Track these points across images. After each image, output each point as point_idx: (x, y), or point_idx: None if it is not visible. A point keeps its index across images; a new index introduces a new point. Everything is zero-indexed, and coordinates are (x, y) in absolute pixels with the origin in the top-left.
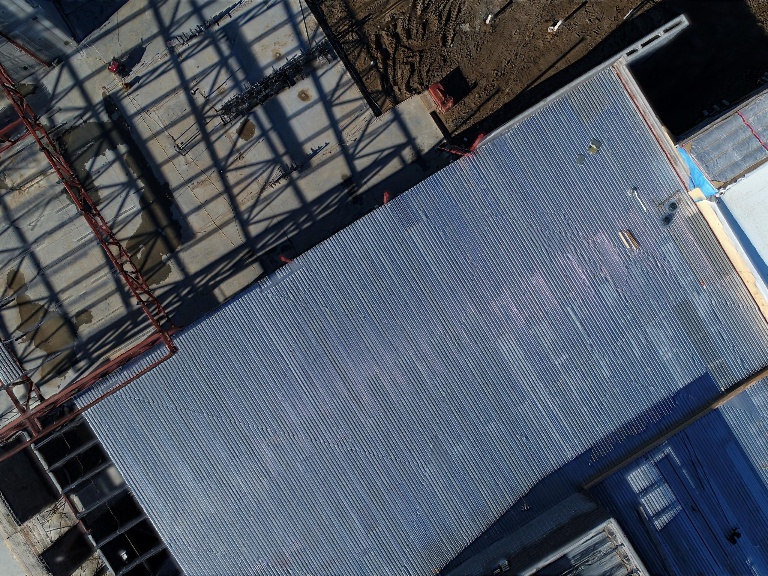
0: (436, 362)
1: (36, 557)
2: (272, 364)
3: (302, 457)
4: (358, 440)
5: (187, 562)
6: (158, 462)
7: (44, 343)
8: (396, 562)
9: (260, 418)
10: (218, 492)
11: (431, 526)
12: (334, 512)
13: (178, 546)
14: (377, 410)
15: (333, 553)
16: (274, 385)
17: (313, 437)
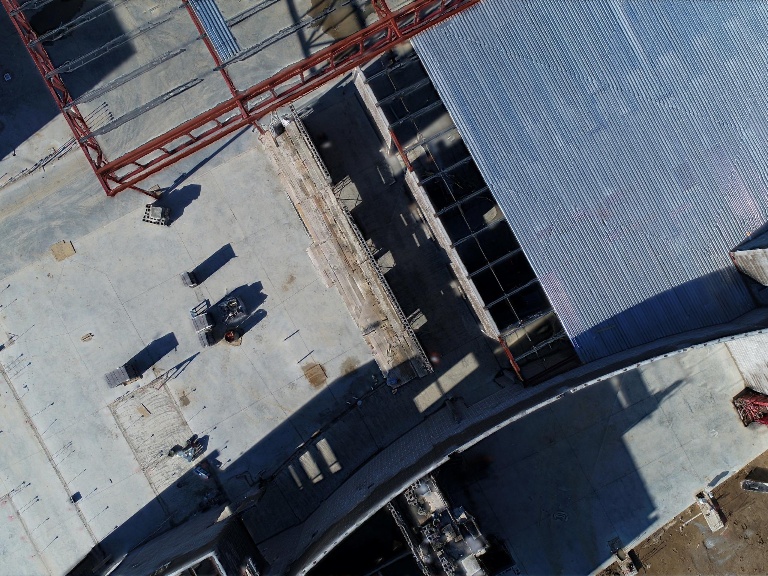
0: (759, 29)
1: (325, 224)
2: (601, 17)
3: (624, 111)
4: (680, 99)
5: (507, 204)
6: (485, 104)
7: (332, 29)
8: (709, 222)
9: (586, 69)
10: (541, 138)
11: (745, 189)
12: (652, 168)
13: (499, 188)
14: (700, 71)
15: (648, 208)
16: (602, 38)
17: (636, 92)
